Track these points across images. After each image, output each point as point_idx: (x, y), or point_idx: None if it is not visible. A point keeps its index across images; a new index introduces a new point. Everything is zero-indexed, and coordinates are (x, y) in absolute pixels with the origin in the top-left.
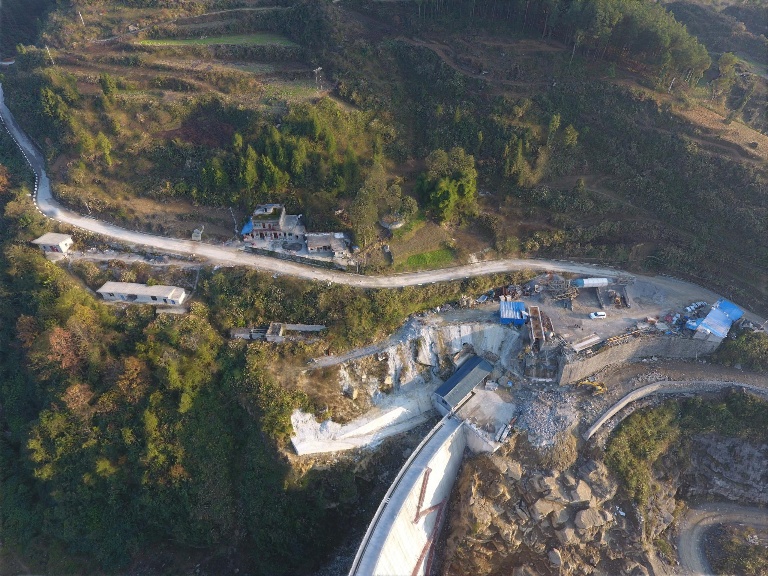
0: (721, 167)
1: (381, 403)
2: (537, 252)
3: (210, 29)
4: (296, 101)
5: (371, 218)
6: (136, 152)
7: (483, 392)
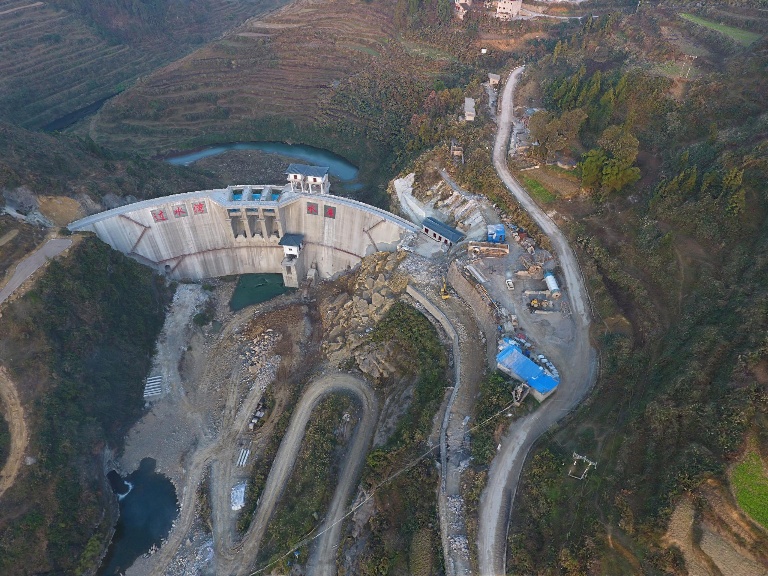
0: (764, 327)
1: (427, 206)
2: (582, 252)
3: (733, 19)
4: (653, 72)
5: (536, 133)
6: (569, 63)
7: (440, 245)
